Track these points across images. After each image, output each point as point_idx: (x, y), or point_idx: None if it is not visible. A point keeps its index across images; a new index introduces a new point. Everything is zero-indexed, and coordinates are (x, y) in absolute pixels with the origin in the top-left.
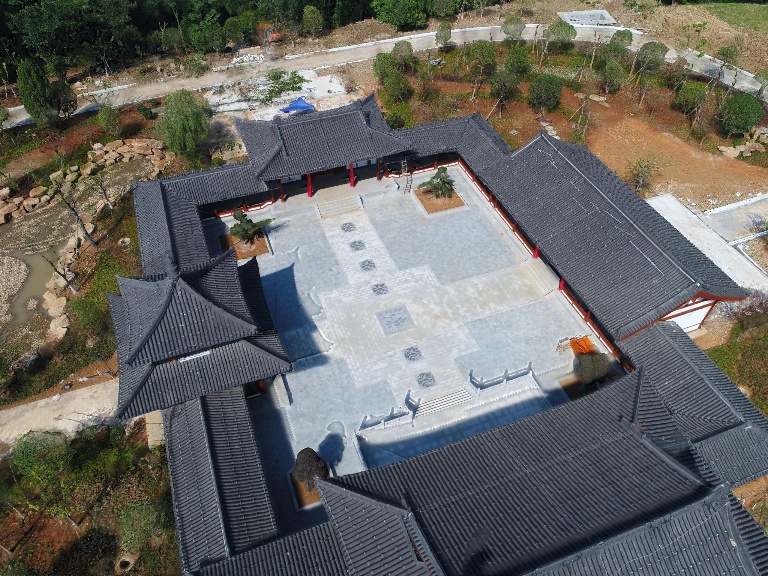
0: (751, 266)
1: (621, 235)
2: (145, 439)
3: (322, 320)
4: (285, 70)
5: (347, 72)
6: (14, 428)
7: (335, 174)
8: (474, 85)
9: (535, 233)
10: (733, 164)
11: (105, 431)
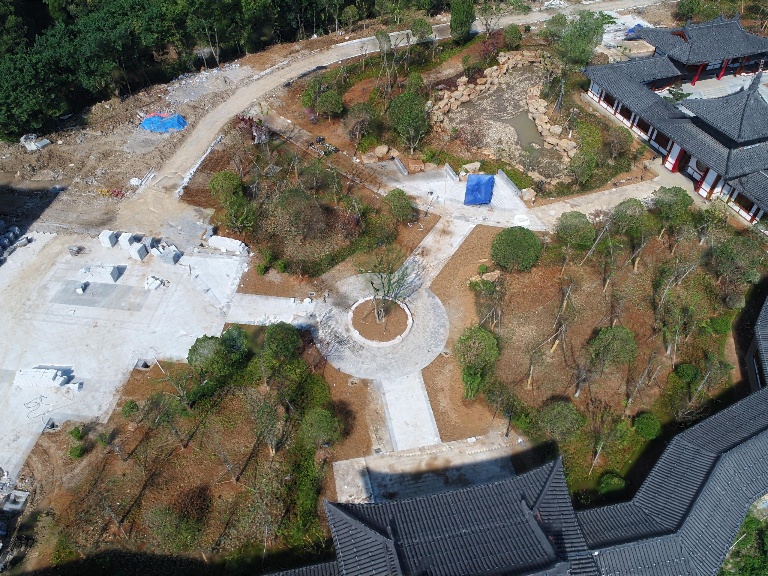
0: None
1: None
2: (695, 210)
3: None
4: (590, 11)
5: (642, 13)
6: (601, 204)
7: None
8: (756, 21)
9: None
10: None
11: None
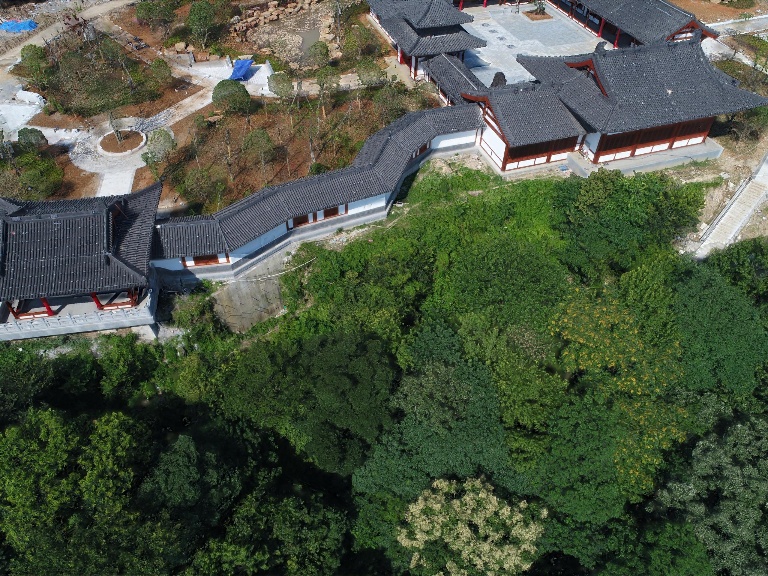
0: (724, 46)
1: (651, 6)
2: (404, 88)
3: (482, 56)
4: None
5: None
6: None
7: (472, 2)
8: None
9: (602, 12)
10: (717, 6)
11: (382, 85)
